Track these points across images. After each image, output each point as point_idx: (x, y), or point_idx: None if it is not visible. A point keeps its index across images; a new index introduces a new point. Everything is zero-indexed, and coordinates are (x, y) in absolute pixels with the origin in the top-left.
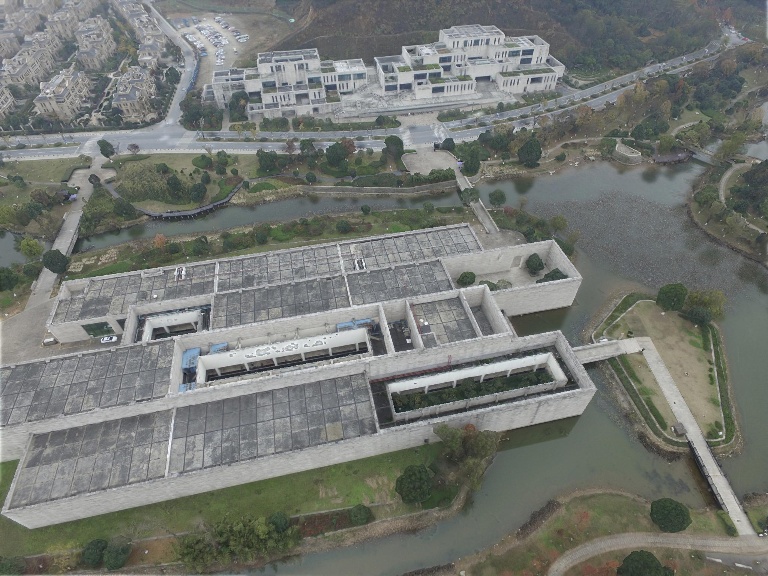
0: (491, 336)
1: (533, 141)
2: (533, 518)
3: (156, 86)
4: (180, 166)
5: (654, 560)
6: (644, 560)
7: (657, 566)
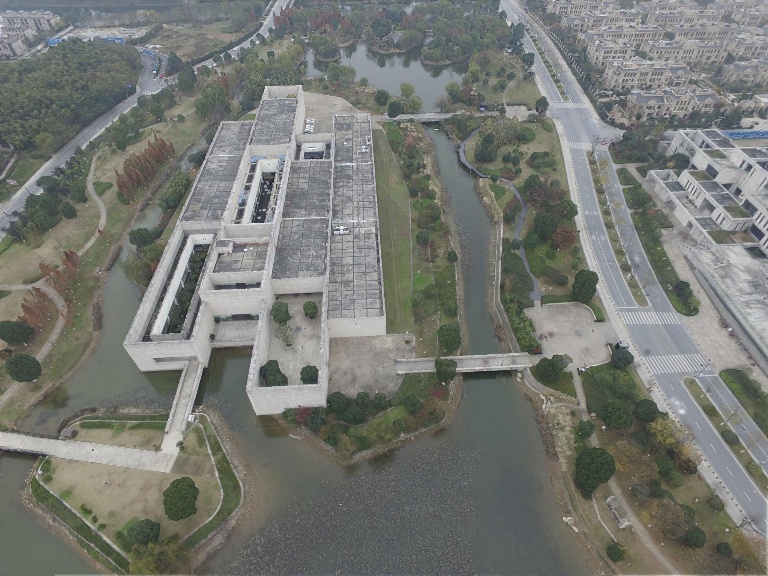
0: (205, 278)
1: (599, 454)
2: (99, 313)
3: (691, 114)
4: (534, 147)
5: (7, 326)
6: (13, 323)
7: (4, 327)
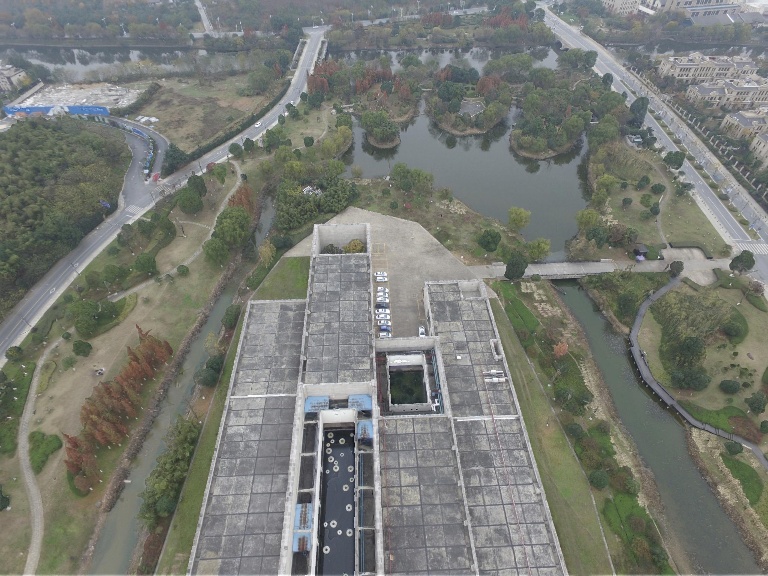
0: None
1: None
2: None
3: None
4: (756, 350)
5: None
6: None
7: None
